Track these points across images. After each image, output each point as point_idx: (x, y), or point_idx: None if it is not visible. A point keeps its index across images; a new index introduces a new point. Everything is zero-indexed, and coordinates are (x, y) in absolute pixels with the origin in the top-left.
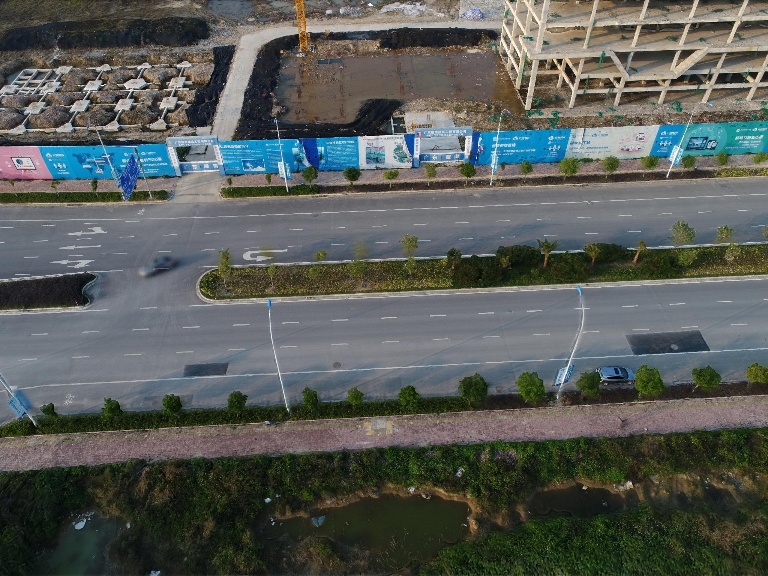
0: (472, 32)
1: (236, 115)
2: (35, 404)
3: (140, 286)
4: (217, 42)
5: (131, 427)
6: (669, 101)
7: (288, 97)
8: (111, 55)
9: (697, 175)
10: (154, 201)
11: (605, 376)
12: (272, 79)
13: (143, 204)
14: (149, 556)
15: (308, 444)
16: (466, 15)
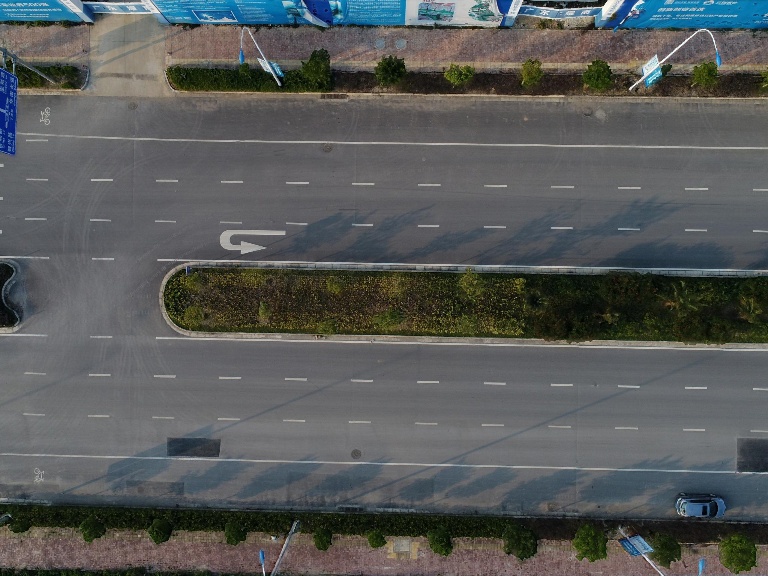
0: None
1: None
2: (1, 480)
3: (81, 293)
4: None
5: (120, 528)
6: None
7: None
8: None
9: None
10: (60, 89)
11: (687, 515)
12: None
13: (44, 95)
14: None
15: (322, 564)
16: None
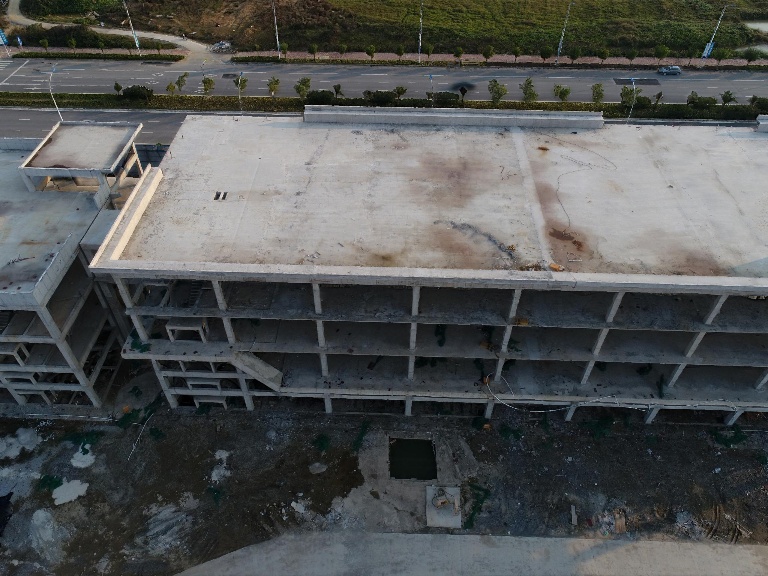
0: None
1: None
2: None
3: None
4: None
5: None
6: None
7: None
8: None
9: None
10: None
11: None
12: None
13: None
14: None
15: None
16: None
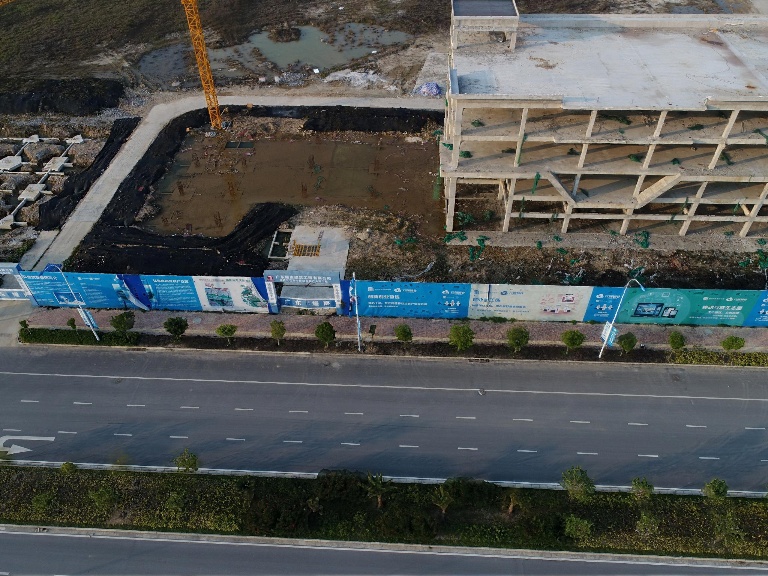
0: (416, 115)
1: (95, 216)
2: None
3: None
4: (123, 112)
5: None
6: (635, 230)
7: (169, 193)
8: (1, 123)
9: (642, 357)
10: None
11: None
12: (160, 167)
13: None
14: None
15: None
16: (420, 90)
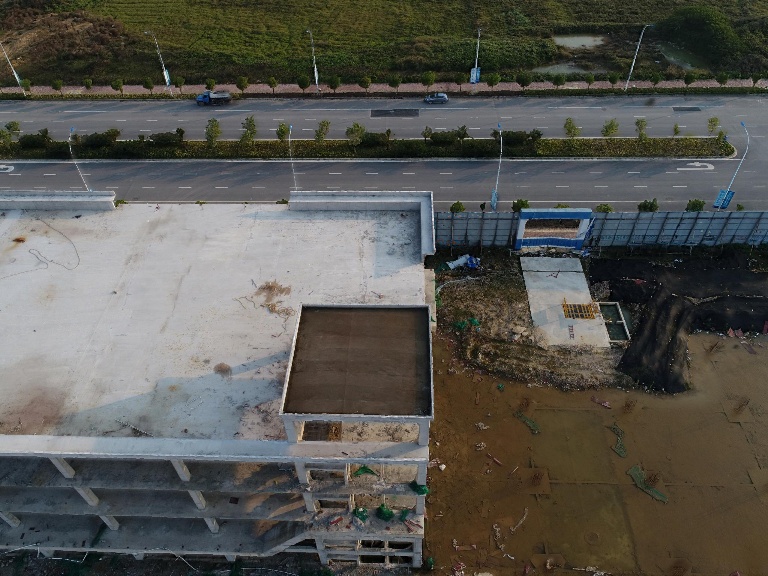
0: None
1: None
2: None
3: None
4: None
5: None
6: None
7: None
8: None
9: None
10: None
11: (445, 94)
12: None
13: None
14: (663, 65)
15: (607, 83)
16: None
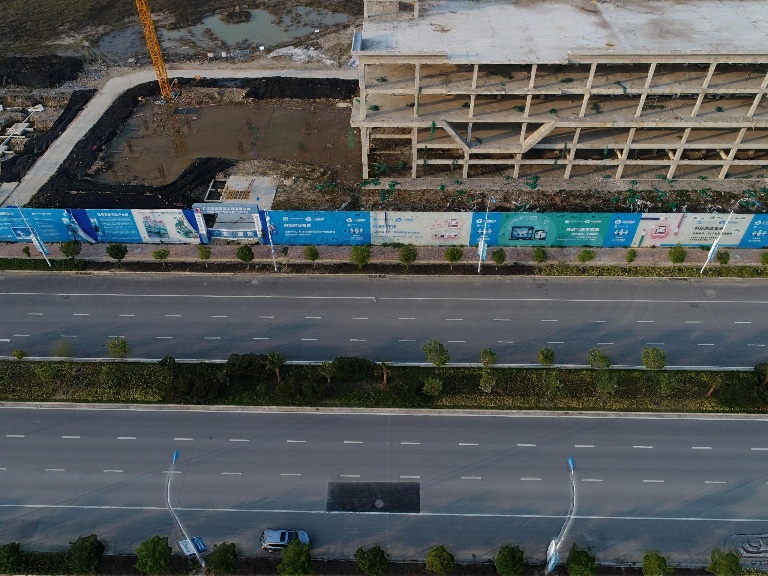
0: (347, 84)
1: (51, 170)
2: None
3: None
4: (81, 85)
5: None
6: (527, 175)
7: (120, 151)
8: None
9: (514, 271)
10: None
11: (266, 542)
12: (112, 130)
13: None
14: None
15: None
16: (355, 63)
